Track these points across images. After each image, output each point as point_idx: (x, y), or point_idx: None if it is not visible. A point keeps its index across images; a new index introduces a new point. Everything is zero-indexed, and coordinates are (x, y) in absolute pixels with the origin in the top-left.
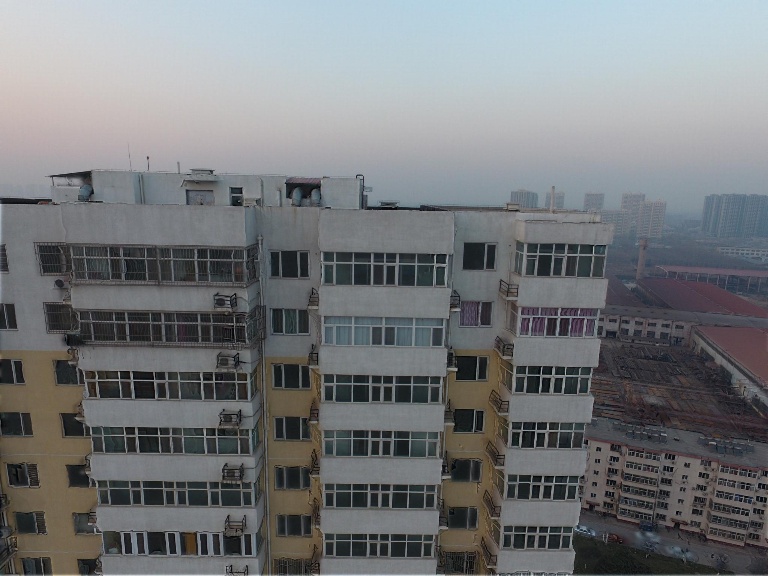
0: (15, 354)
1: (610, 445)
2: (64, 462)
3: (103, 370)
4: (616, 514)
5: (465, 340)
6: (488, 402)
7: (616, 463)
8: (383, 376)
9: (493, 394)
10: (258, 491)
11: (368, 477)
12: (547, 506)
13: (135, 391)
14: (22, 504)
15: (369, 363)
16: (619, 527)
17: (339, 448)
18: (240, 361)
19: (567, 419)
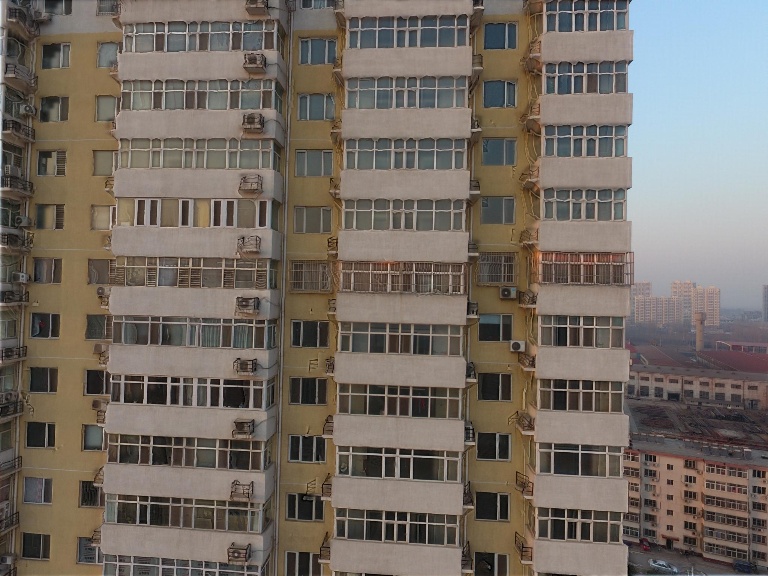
0: (65, 37)
1: (683, 461)
2: (92, 147)
3: (141, 22)
4: (701, 552)
5: (492, 5)
6: (519, 64)
7: (693, 484)
8: (408, 20)
9: (524, 57)
10: (277, 166)
11: (392, 129)
12: (592, 163)
13: (168, 45)
14: (45, 194)
15: (394, 3)
16: (707, 566)
17: (362, 100)
18: (269, 7)
19: (606, 57)
